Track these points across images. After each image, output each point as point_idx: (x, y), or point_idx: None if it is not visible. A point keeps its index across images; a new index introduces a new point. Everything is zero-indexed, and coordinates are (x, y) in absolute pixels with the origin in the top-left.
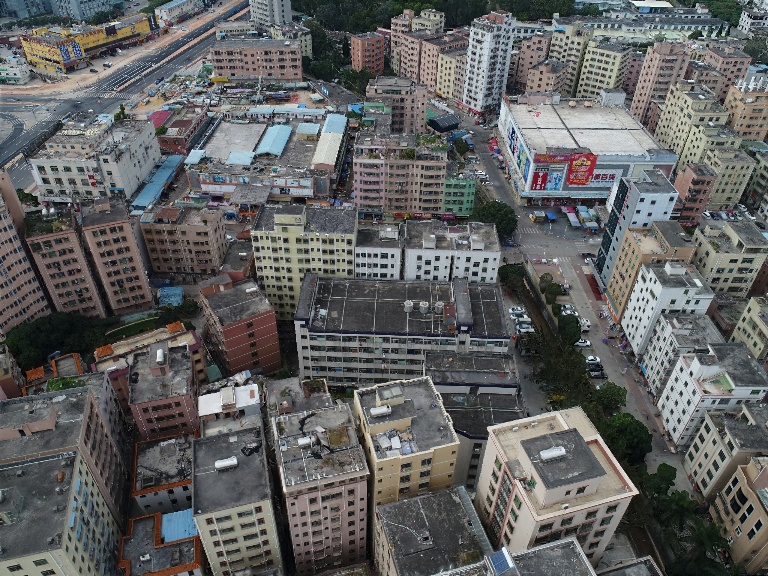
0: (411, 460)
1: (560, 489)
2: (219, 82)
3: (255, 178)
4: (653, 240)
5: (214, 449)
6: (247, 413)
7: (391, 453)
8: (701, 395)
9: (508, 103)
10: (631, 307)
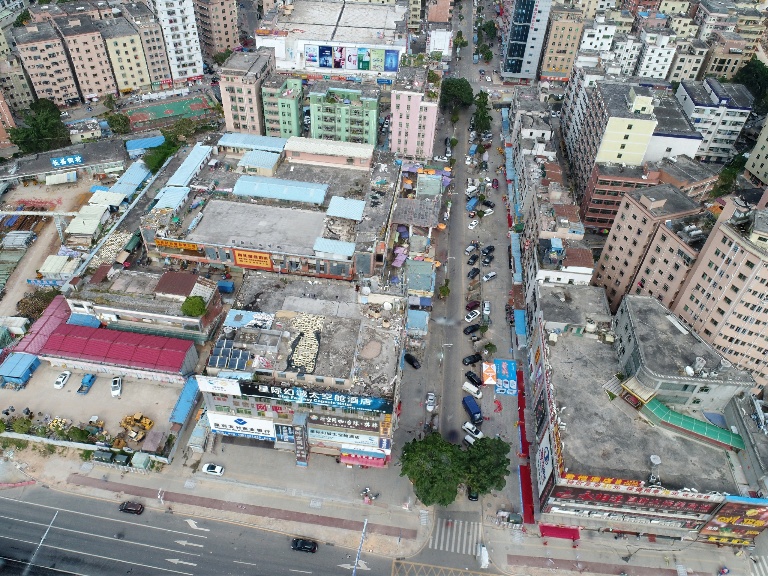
0: None
1: None
2: None
3: None
4: (562, 20)
5: None
6: None
7: None
8: None
9: (283, 33)
10: None
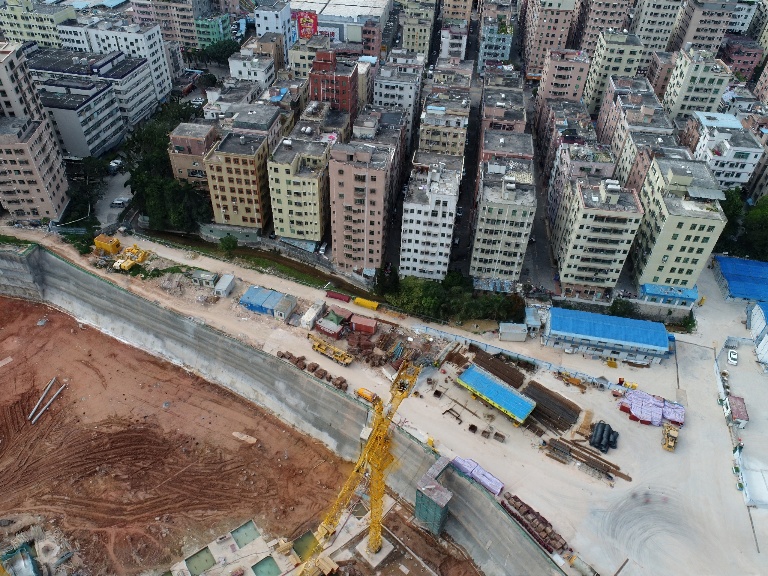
0: None
1: None
2: None
3: None
4: None
5: None
6: None
7: None
8: None
9: None
10: None
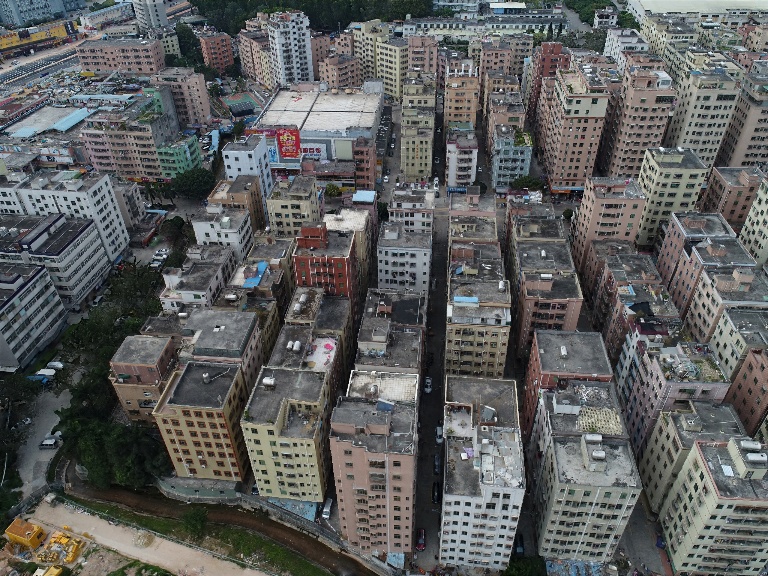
0: None
1: None
2: (88, 76)
3: (25, 147)
4: None
5: None
6: None
7: None
8: None
9: (275, 90)
10: None
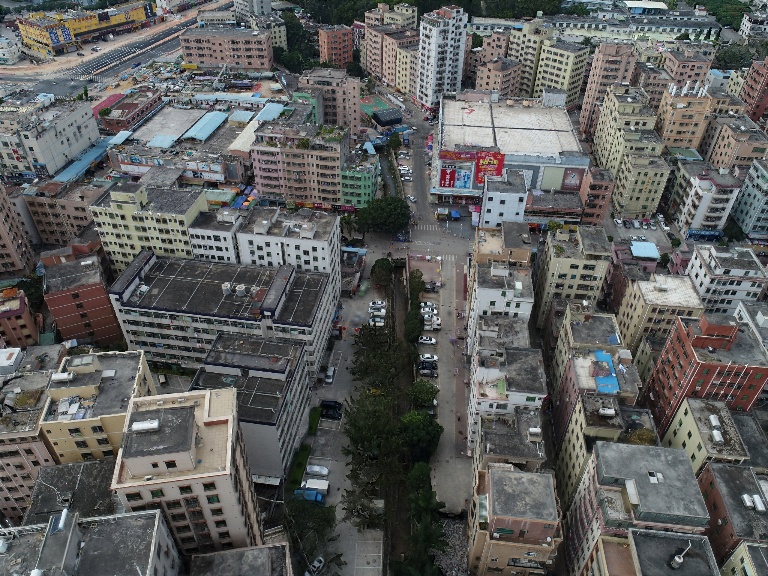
0: (77, 426)
1: (140, 460)
2: (189, 69)
3: (168, 161)
4: (499, 240)
5: None
6: None
7: (62, 417)
8: (476, 397)
9: (442, 99)
10: (471, 307)
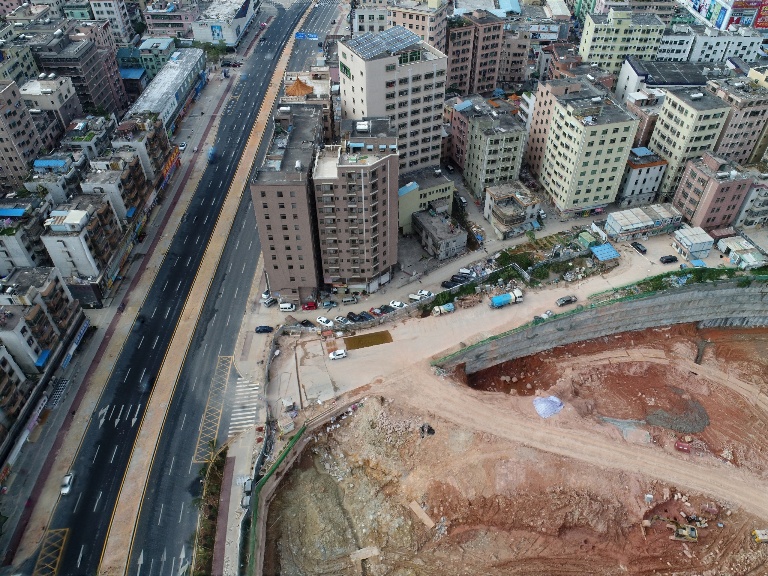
0: None
1: None
2: None
3: (516, 25)
4: None
5: (681, 95)
6: (658, 102)
7: None
8: None
9: None
10: None
